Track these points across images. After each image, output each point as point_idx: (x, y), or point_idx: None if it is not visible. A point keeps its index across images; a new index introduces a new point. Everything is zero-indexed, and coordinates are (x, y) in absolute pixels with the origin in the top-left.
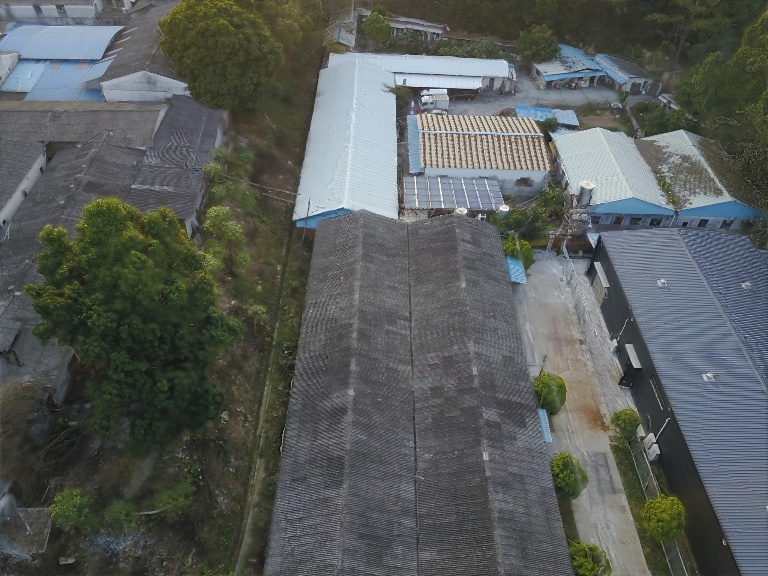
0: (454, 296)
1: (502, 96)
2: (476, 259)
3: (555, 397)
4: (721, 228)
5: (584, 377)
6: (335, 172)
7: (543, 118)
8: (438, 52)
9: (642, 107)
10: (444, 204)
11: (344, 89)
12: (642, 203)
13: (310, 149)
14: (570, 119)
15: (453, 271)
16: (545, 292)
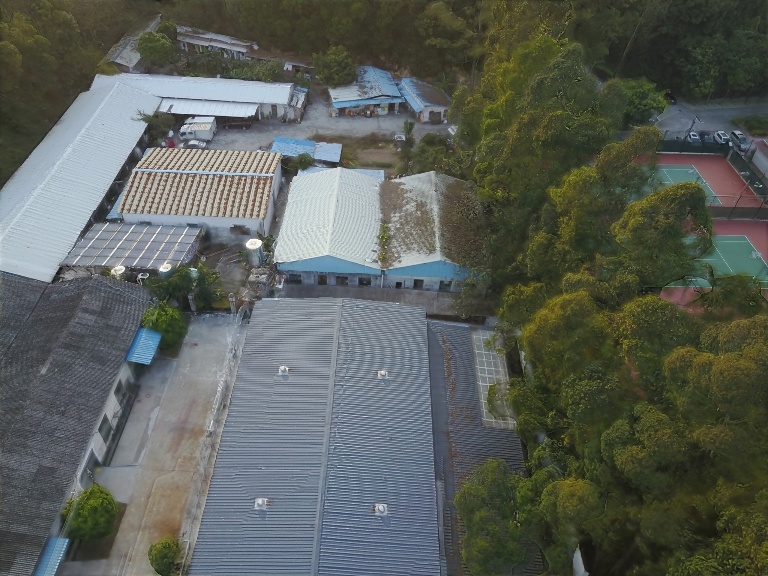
0: (25, 385)
1: (285, 124)
2: (88, 335)
3: (82, 523)
4: (441, 289)
5: (186, 482)
6: (4, 219)
7: (298, 153)
8: (229, 74)
9: (429, 140)
10: (108, 260)
11: (83, 117)
12: (341, 261)
13: (5, 188)
14: (331, 154)
15: (45, 351)
16: (201, 367)
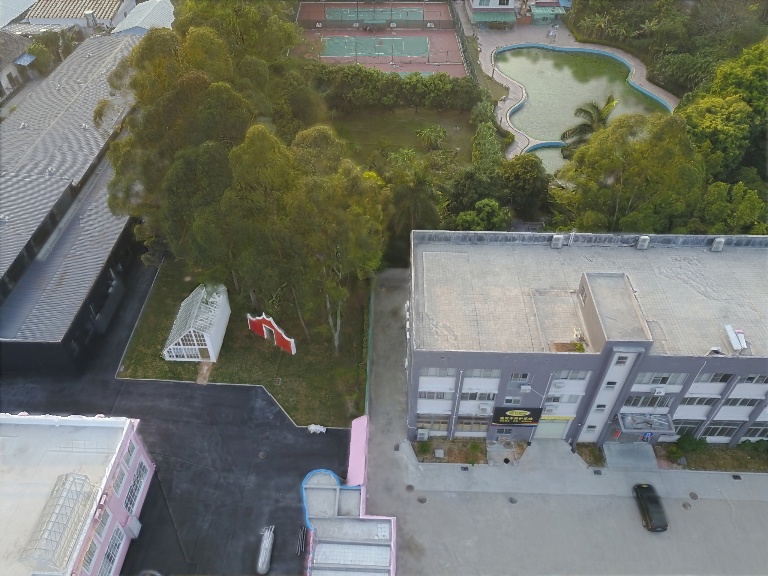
0: None
1: None
2: None
3: None
4: None
5: None
6: None
7: None
8: None
9: None
10: (14, 32)
11: None
12: None
13: None
14: None
15: None
16: None
